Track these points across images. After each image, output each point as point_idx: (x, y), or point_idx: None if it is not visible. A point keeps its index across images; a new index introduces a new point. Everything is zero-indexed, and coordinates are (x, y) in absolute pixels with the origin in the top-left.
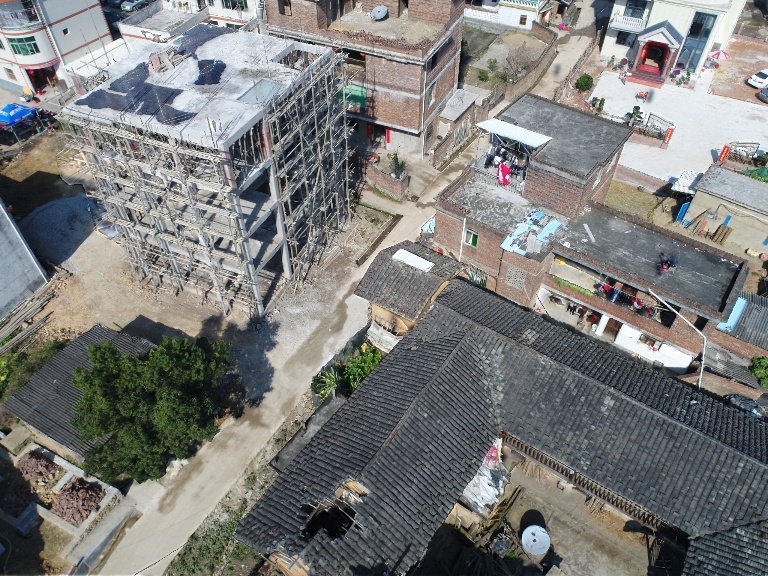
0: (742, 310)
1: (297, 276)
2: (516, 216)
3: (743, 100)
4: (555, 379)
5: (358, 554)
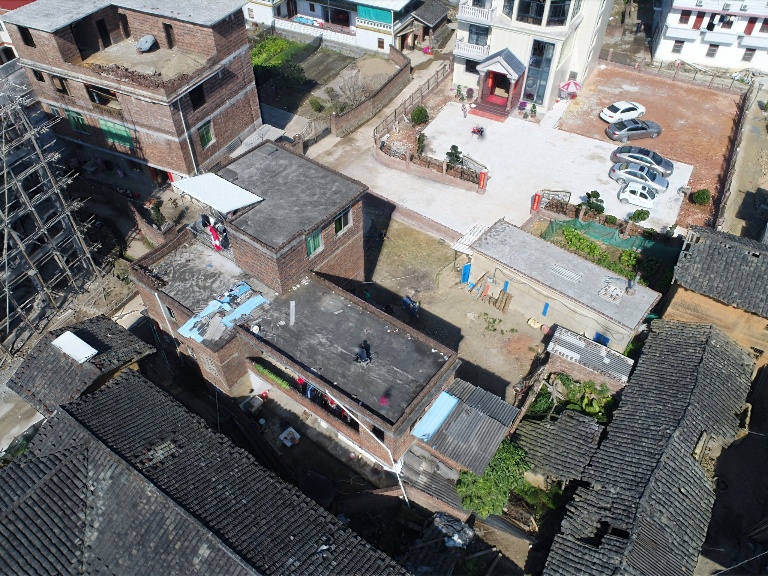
0: (449, 413)
1: (8, 348)
2: (217, 290)
3: (589, 136)
4: (156, 516)
5: None
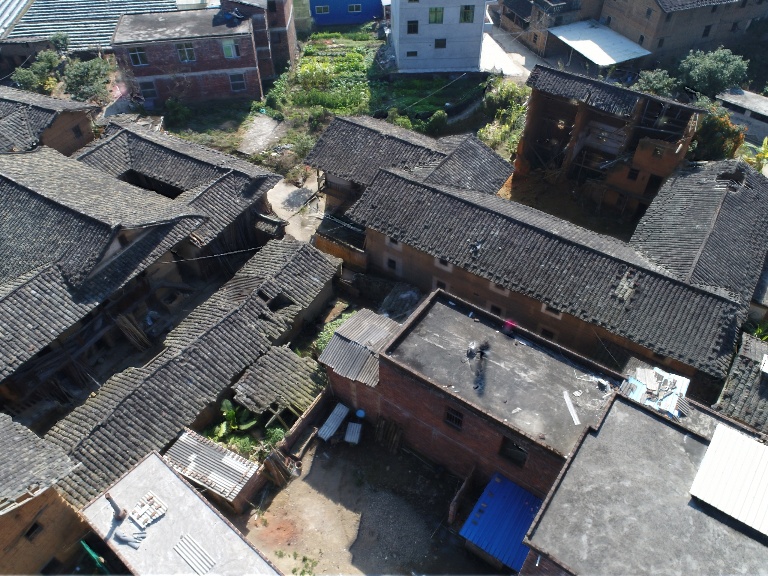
0: None
1: None
2: None
3: None
4: None
5: (703, 174)
